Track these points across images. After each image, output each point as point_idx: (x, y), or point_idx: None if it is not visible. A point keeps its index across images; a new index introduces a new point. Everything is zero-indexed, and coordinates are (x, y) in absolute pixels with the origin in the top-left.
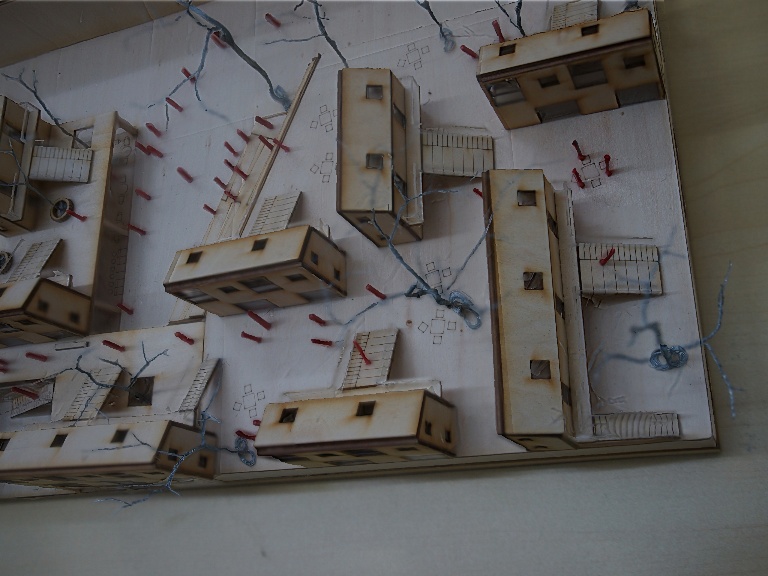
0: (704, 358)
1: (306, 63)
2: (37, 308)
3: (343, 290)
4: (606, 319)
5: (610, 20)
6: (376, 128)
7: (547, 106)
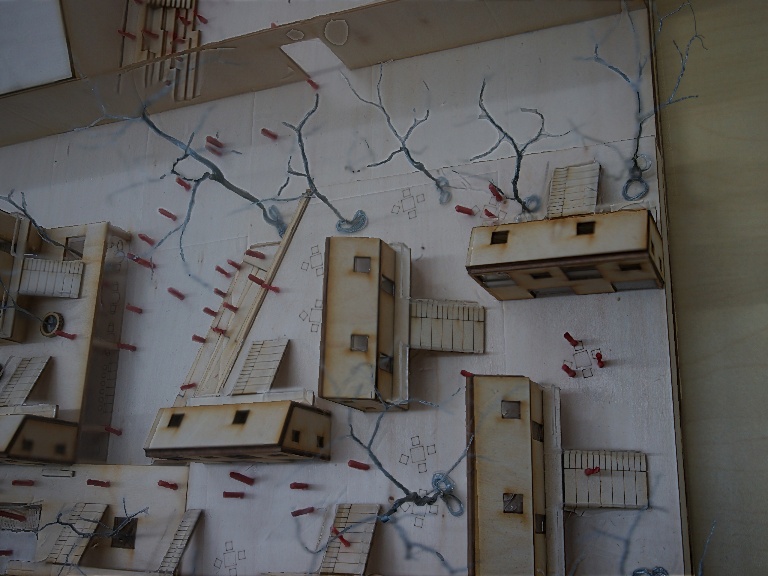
0: (688, 575)
1: (302, 183)
2: (21, 448)
3: (326, 455)
4: (589, 526)
5: (607, 219)
6: (362, 305)
7: (540, 288)
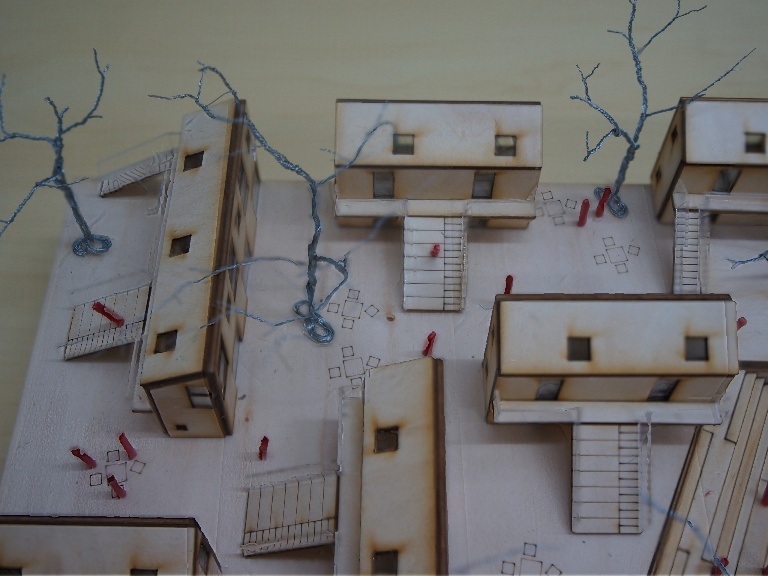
0: None
1: None
2: None
3: None
4: None
5: None
6: (383, 496)
7: None
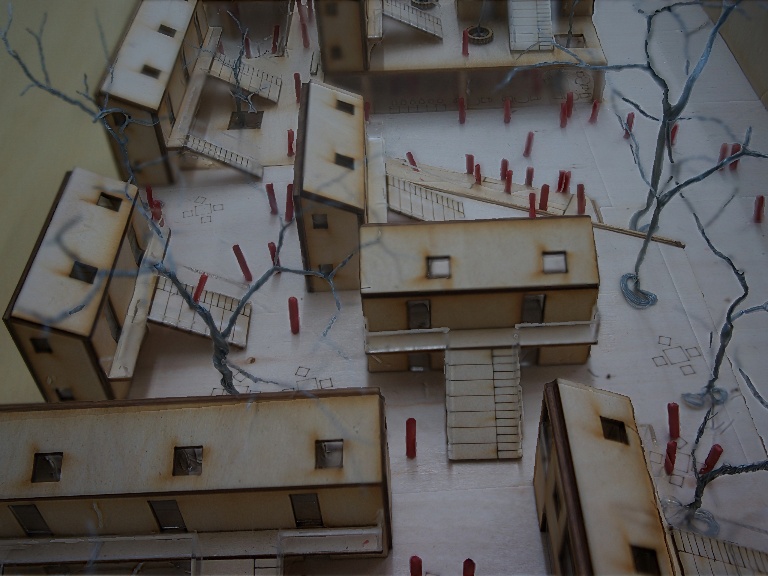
0: None
1: (695, 254)
2: (327, 2)
3: (313, 285)
4: None
5: None
6: (493, 267)
7: None
